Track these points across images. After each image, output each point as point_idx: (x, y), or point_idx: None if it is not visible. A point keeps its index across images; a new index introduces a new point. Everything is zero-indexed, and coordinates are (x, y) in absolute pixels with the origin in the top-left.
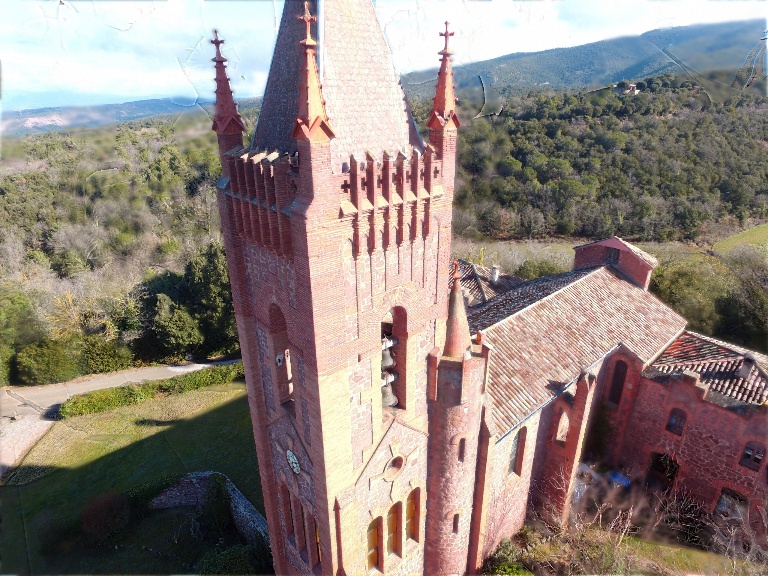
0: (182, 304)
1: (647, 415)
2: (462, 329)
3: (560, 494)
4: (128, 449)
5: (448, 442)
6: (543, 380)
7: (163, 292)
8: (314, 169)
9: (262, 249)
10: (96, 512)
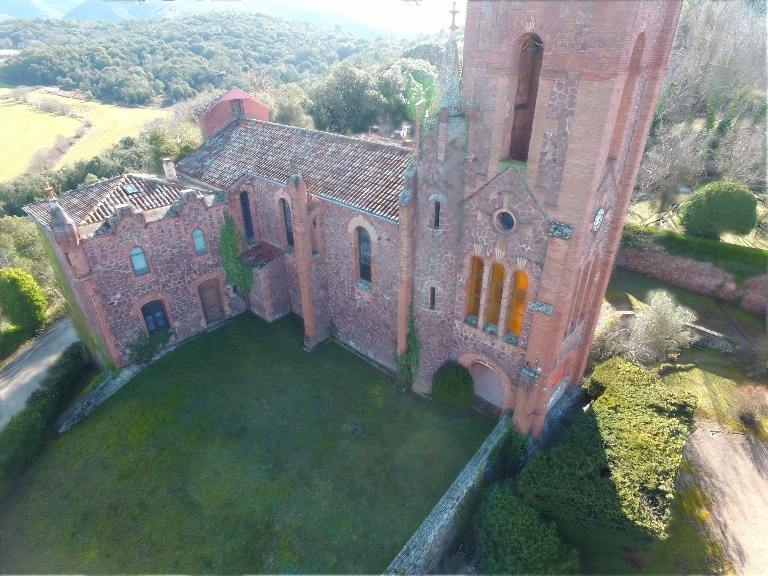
0: None
1: None
2: None
3: None
4: None
5: None
6: None
7: None
8: None
9: None
10: None
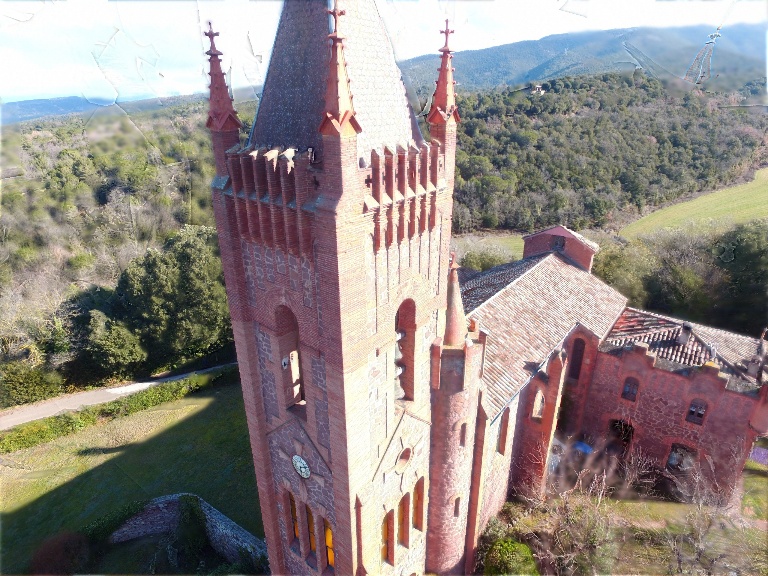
0: (119, 320)
1: (604, 386)
2: (460, 318)
3: (538, 468)
4: (74, 483)
5: (450, 428)
6: (520, 362)
7: (94, 308)
8: (343, 164)
9: (268, 250)
10: (50, 556)
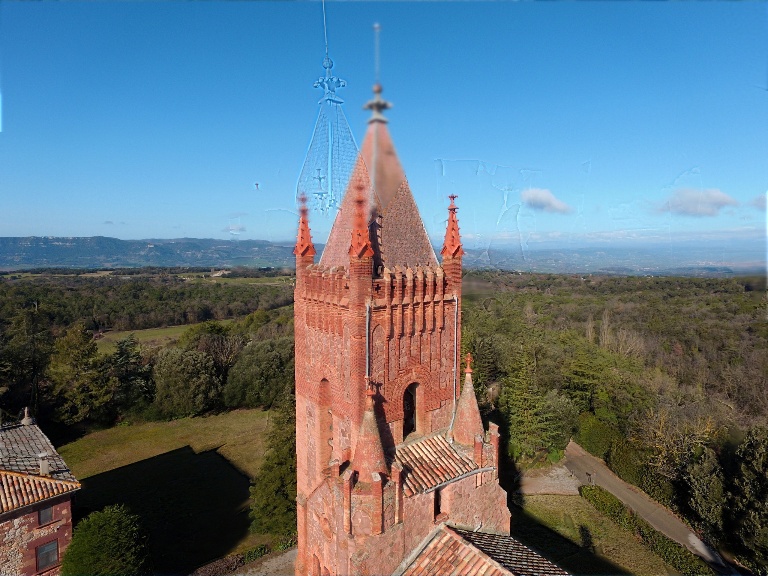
0: (724, 473)
1: None
2: None
3: None
4: (558, 537)
5: None
6: None
7: None
8: None
9: None
10: None
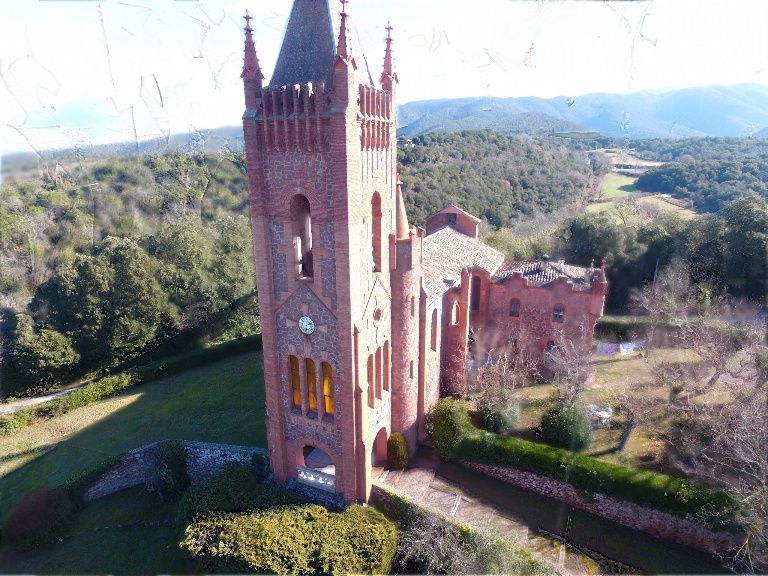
0: (49, 323)
1: (497, 310)
2: (405, 219)
3: (460, 365)
4: (25, 468)
5: (404, 300)
6: (440, 279)
7: None
8: (349, 85)
9: (287, 156)
10: (31, 508)
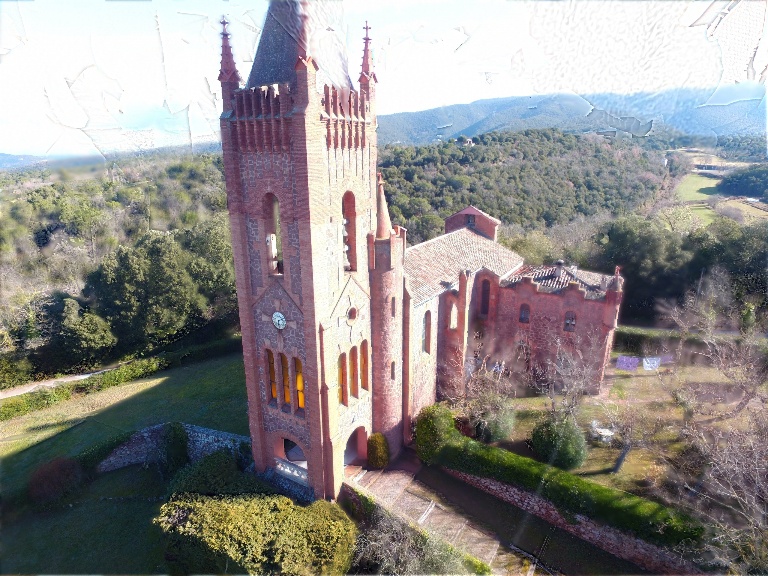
0: (92, 308)
1: (507, 315)
2: (387, 219)
3: (458, 370)
4: (56, 438)
5: (384, 301)
6: (437, 281)
7: None
8: (309, 86)
9: (259, 155)
10: (47, 474)
